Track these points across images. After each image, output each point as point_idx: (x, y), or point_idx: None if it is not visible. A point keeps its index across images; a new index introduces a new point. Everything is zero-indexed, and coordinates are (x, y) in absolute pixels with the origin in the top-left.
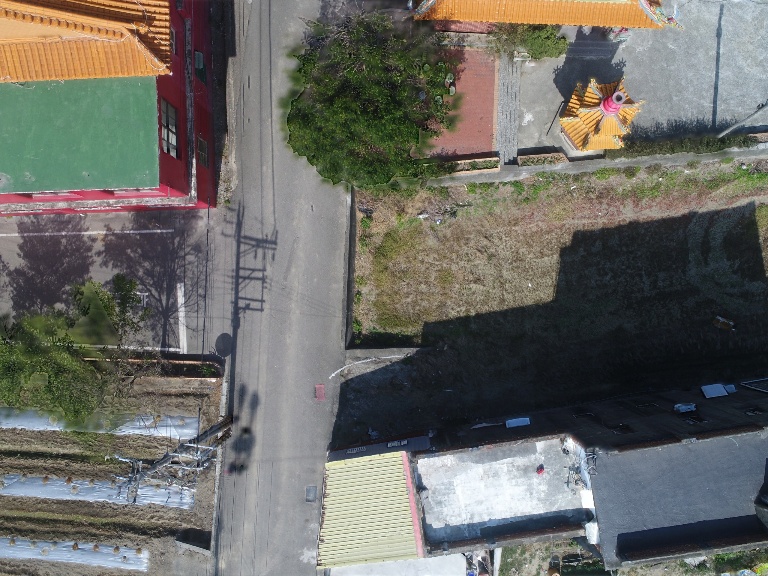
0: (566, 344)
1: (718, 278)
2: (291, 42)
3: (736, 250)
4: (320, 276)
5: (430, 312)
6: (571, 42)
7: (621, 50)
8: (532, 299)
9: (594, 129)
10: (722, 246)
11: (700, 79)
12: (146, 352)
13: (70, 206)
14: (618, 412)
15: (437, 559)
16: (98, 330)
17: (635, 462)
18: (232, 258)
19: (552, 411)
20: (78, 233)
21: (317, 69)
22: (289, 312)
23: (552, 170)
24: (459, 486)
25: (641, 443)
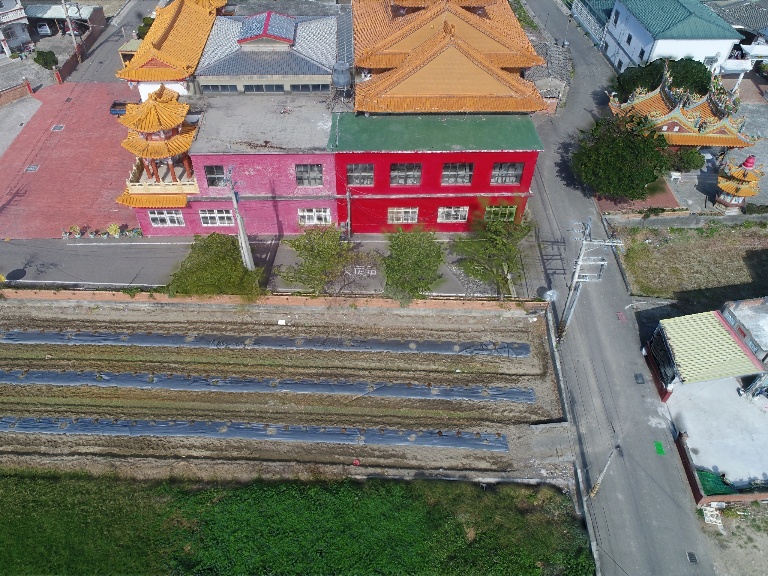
0: None
1: None
2: (549, 166)
3: None
4: None
5: (674, 287)
6: (698, 175)
7: None
8: (738, 281)
9: (743, 177)
10: None
11: None
12: None
13: (457, 196)
14: None
15: (762, 425)
16: (450, 286)
17: None
18: (536, 251)
19: None
20: (430, 241)
21: None
22: None
23: (718, 219)
24: (765, 326)
25: None
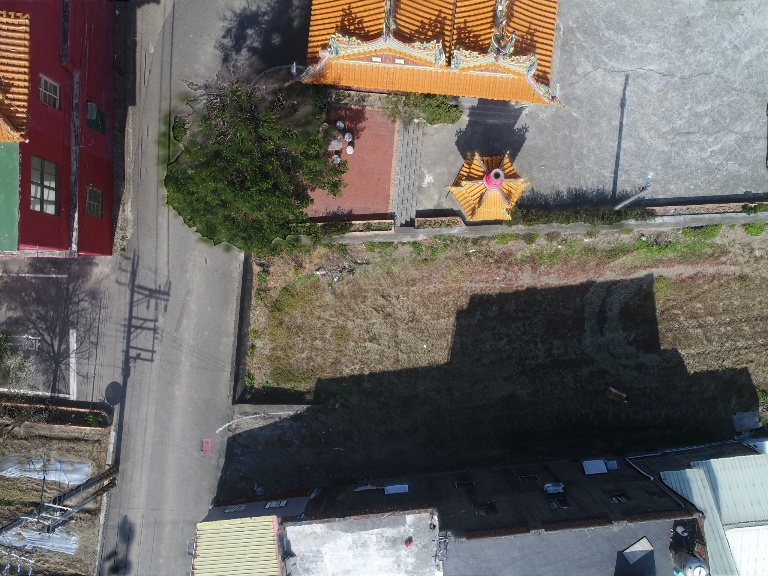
0: (458, 408)
1: (613, 349)
2: (191, 94)
3: (632, 322)
4: (211, 329)
5: (324, 369)
6: (474, 106)
7: (524, 115)
8: (426, 360)
9: (478, 202)
10: (618, 317)
11: (602, 148)
12: (36, 397)
13: None
14: (496, 484)
15: None
16: None
17: (487, 548)
18: (125, 307)
19: (439, 476)
20: None
21: (188, 136)
22: (179, 364)
23: (449, 233)
24: (327, 554)
25: (493, 530)
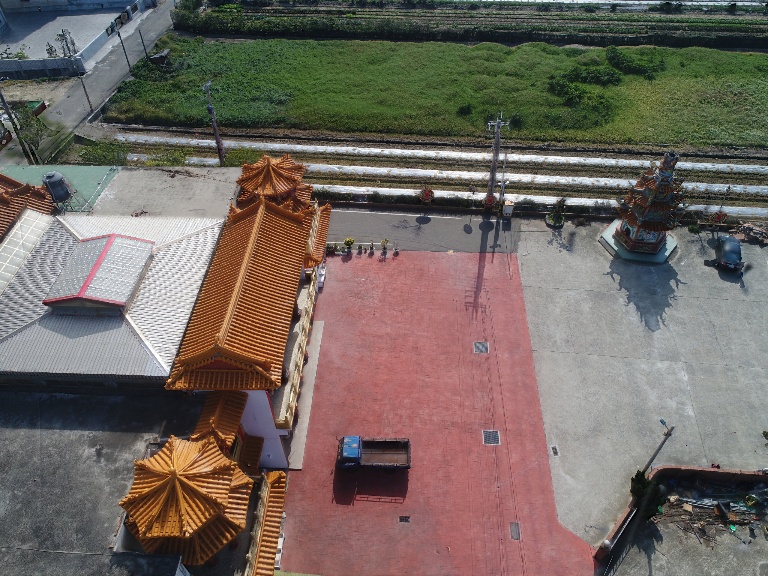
0: None
1: None
2: None
3: None
4: None
5: None
6: None
7: None
8: None
9: None
10: None
11: None
12: None
13: None
14: None
15: None
16: None
17: None
18: None
19: None
20: None
21: None
22: None
23: None
24: None
25: None
